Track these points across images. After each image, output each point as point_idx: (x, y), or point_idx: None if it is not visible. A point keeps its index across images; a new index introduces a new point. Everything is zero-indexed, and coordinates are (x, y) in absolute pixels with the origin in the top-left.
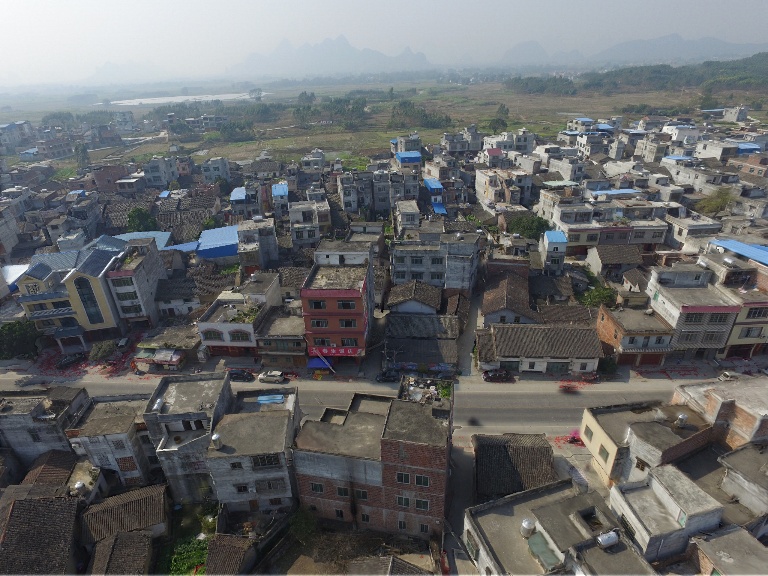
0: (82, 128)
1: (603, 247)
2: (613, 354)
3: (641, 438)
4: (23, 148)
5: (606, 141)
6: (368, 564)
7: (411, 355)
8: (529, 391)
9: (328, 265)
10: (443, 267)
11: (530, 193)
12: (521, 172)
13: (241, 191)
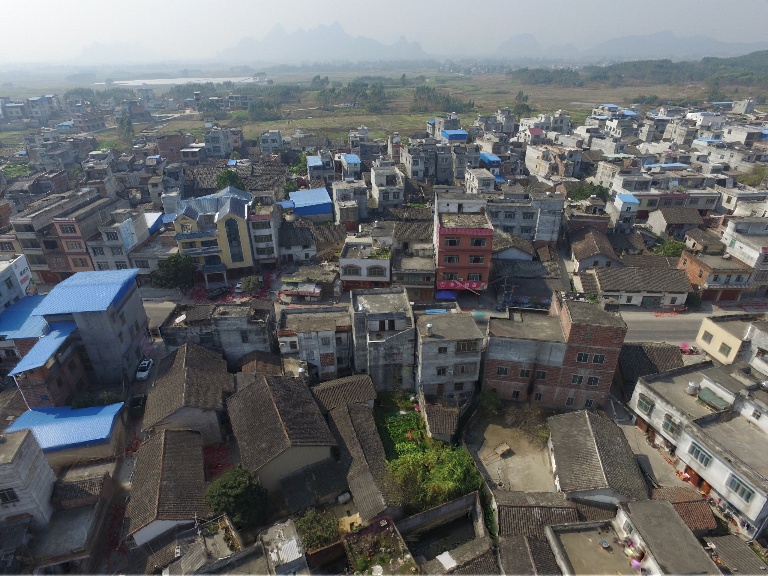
0: (110, 103)
1: (667, 209)
2: (698, 290)
3: (764, 331)
4: (56, 121)
5: (636, 125)
6: (566, 418)
7: (524, 290)
8: (631, 319)
9: (448, 213)
10: (533, 222)
11: (579, 168)
12: (571, 148)
13: (316, 158)
